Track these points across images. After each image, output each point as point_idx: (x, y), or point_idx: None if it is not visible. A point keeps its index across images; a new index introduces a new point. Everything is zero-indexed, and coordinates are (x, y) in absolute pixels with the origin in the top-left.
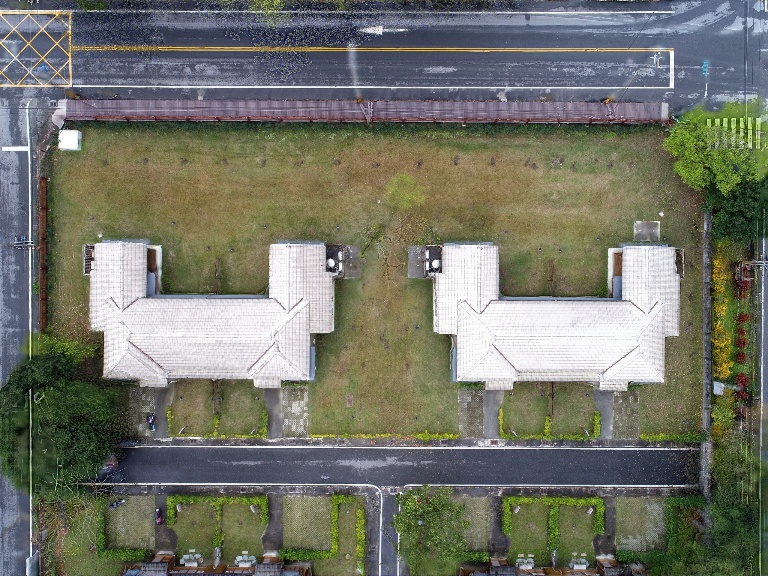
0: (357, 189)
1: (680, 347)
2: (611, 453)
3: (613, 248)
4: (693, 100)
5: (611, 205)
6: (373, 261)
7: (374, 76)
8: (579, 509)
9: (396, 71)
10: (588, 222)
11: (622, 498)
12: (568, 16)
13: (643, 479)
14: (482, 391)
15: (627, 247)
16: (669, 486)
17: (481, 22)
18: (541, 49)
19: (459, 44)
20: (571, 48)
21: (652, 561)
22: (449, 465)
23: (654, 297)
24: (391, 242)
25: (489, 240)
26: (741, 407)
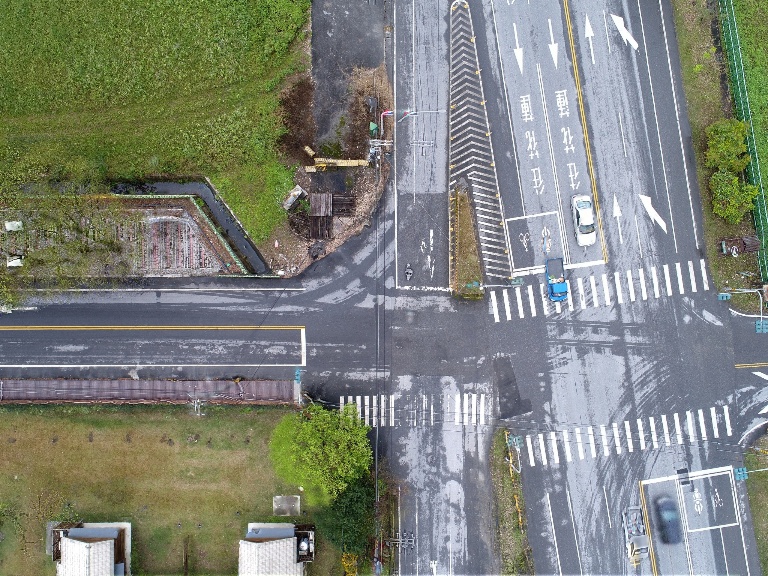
0: None
1: None
2: None
3: (253, 522)
4: (325, 378)
5: (250, 480)
6: (10, 538)
7: (4, 355)
8: None
9: (26, 349)
10: (227, 497)
11: None
12: (199, 293)
13: None
14: None
15: (242, 541)
16: None
17: (111, 299)
18: (172, 327)
19: (89, 322)
20: (202, 326)
21: None
22: None
23: None
24: (29, 518)
25: (128, 515)
26: None
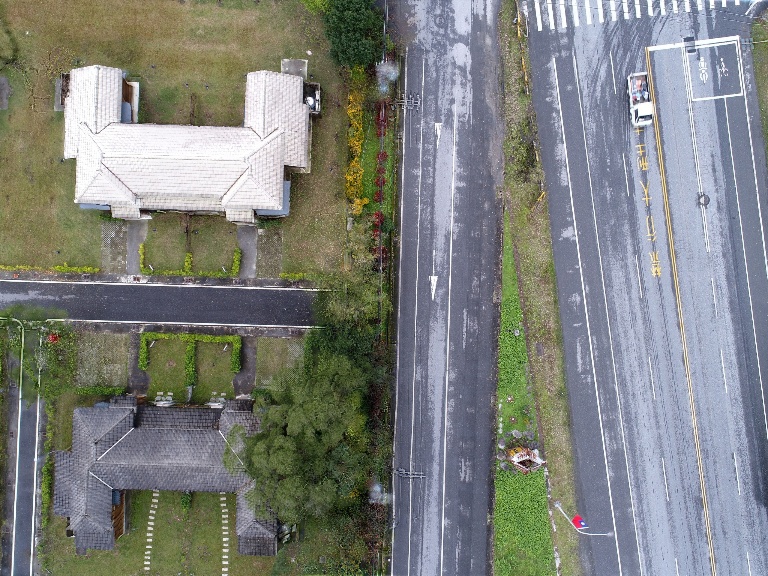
0: (6, 20)
1: (325, 187)
2: (253, 292)
3: None
4: None
5: (259, 42)
6: (19, 92)
7: None
8: (215, 346)
9: None
10: (236, 59)
11: (263, 338)
12: None
13: (285, 319)
14: (126, 226)
15: (249, 73)
16: (311, 327)
17: None
18: None
19: None
20: None
21: (284, 399)
22: (91, 300)
23: (273, 123)
24: (38, 74)
25: (137, 75)
26: (381, 247)
